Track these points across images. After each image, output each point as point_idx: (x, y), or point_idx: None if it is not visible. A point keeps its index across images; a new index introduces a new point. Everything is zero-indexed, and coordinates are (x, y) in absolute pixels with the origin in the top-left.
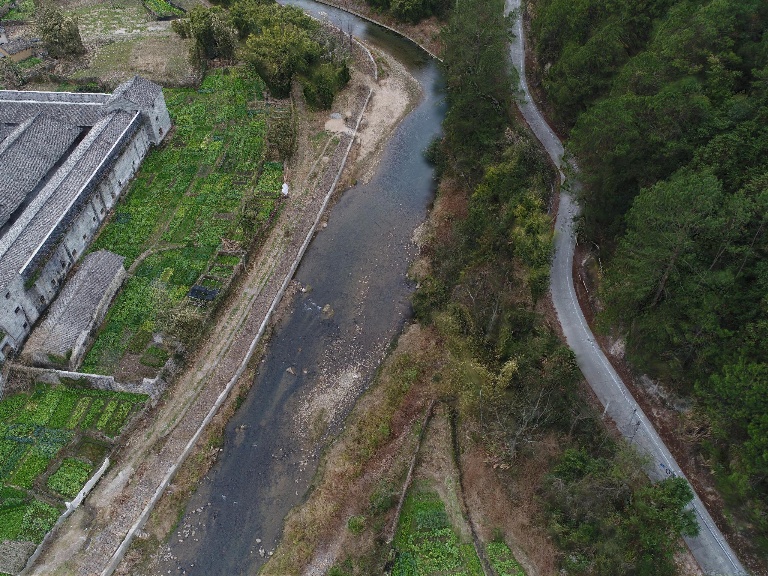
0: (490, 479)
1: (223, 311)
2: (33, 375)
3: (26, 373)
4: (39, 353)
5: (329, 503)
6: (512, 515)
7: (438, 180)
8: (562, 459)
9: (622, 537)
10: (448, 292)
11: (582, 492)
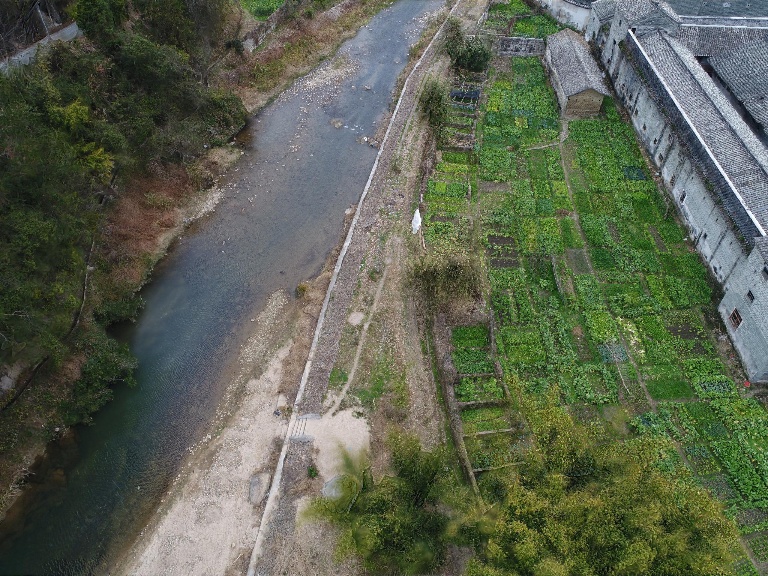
0: None
1: None
2: None
3: None
4: None
5: None
6: None
7: (136, 297)
8: None
9: None
10: (204, 87)
11: None
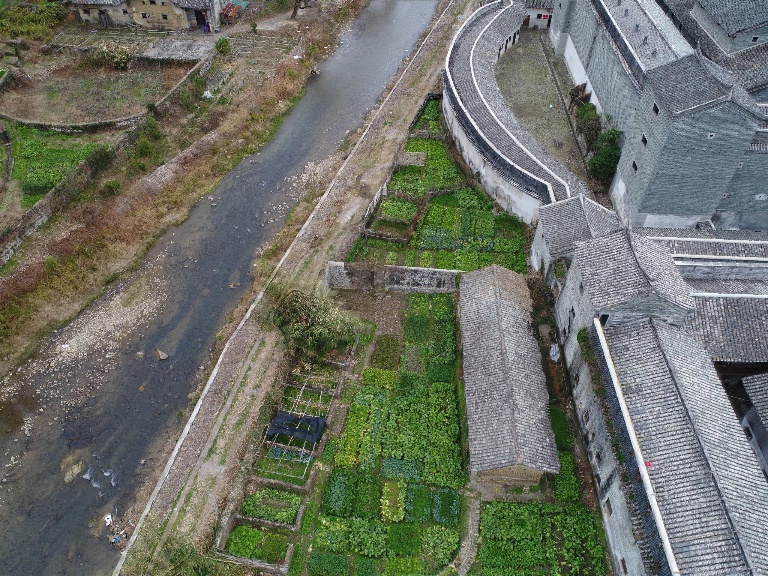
0: None
1: None
2: None
3: None
4: None
5: None
6: None
7: None
8: None
9: None
10: None
11: None
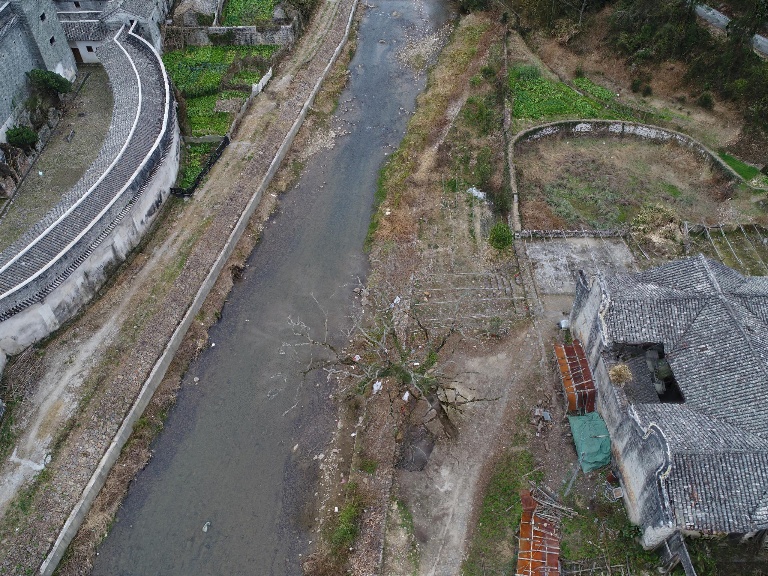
0: (564, 52)
1: (316, 10)
2: (186, 34)
3: (180, 33)
4: (190, 13)
5: (447, 86)
6: (587, 60)
7: None
8: (620, 3)
9: (674, 18)
10: None
11: (641, 5)
